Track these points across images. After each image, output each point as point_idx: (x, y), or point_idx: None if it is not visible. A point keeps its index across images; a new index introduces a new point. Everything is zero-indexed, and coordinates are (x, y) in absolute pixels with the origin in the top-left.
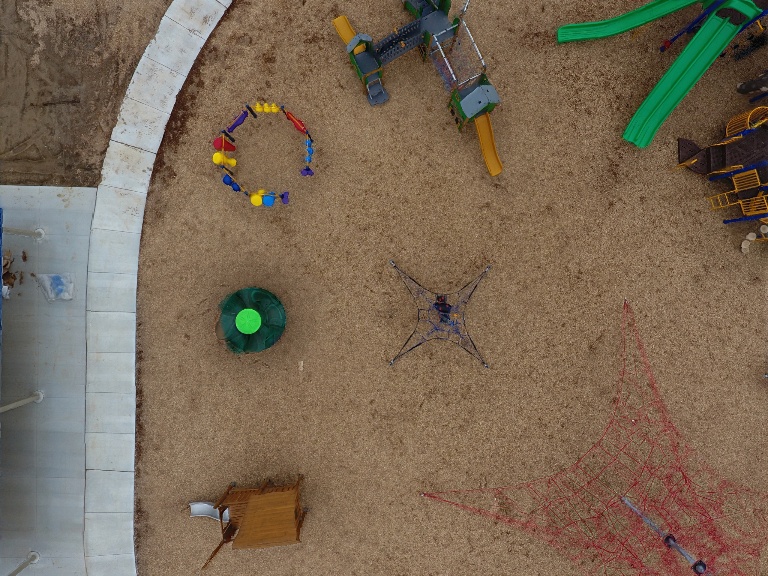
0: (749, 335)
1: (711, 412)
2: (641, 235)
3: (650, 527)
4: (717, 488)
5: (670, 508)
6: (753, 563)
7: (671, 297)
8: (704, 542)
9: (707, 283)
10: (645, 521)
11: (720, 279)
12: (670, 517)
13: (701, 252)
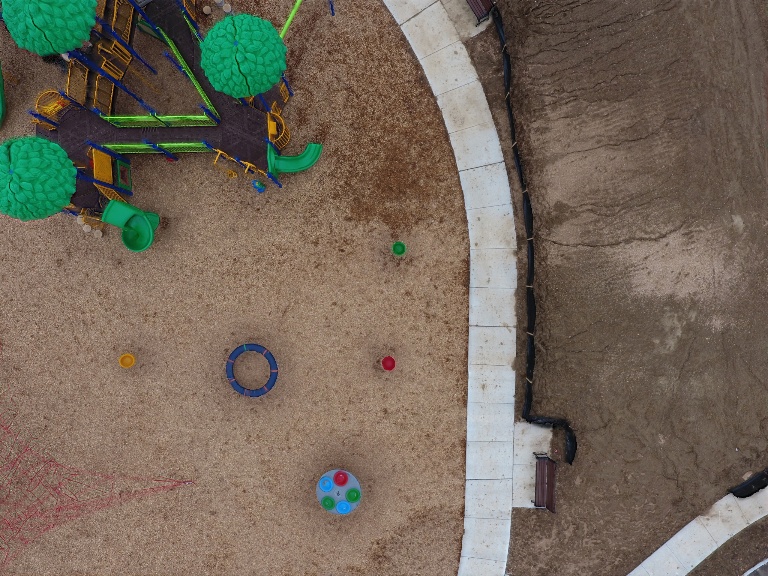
0: (113, 319)
1: (76, 395)
2: (4, 220)
3: (17, 509)
4: (83, 470)
5: (36, 490)
6: (122, 545)
7: (34, 281)
8: (72, 524)
9: (70, 268)
10: (11, 503)
11: (83, 264)
12: (36, 499)
13: (64, 237)
